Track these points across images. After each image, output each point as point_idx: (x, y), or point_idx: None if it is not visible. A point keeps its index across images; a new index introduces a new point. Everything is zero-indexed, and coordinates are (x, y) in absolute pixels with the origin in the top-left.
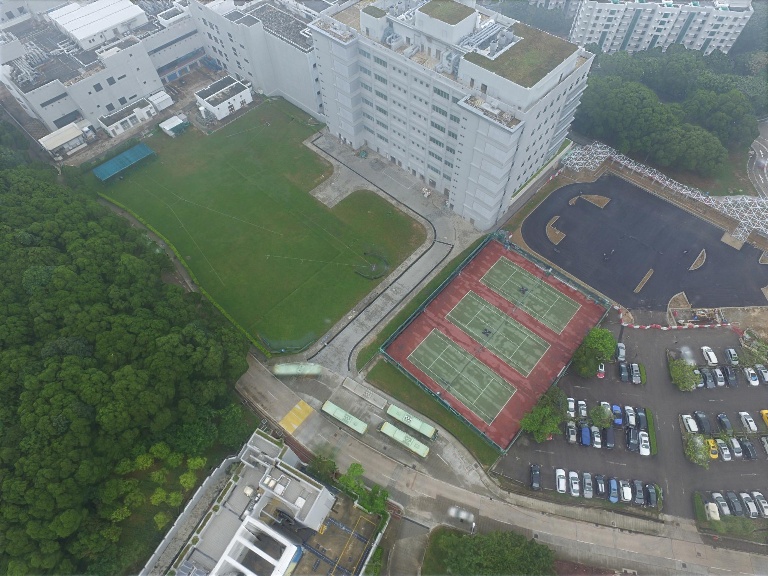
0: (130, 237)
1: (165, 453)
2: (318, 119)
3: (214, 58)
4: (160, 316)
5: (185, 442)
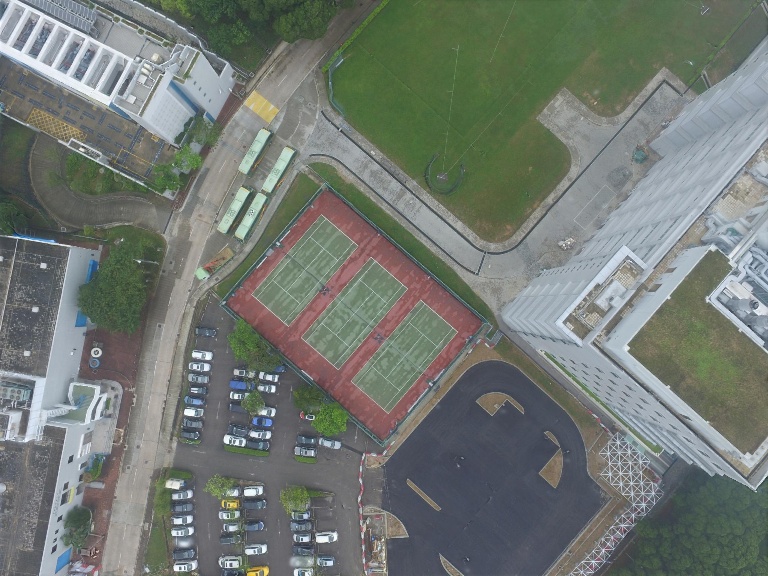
0: None
1: None
2: None
3: None
4: None
5: None
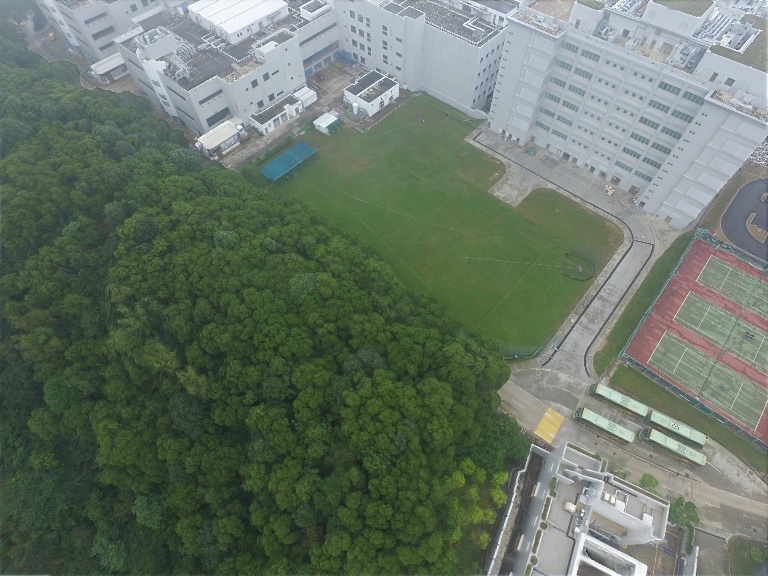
0: (351, 241)
1: (474, 469)
2: (469, 115)
3: (350, 52)
4: (430, 324)
5: (484, 456)
